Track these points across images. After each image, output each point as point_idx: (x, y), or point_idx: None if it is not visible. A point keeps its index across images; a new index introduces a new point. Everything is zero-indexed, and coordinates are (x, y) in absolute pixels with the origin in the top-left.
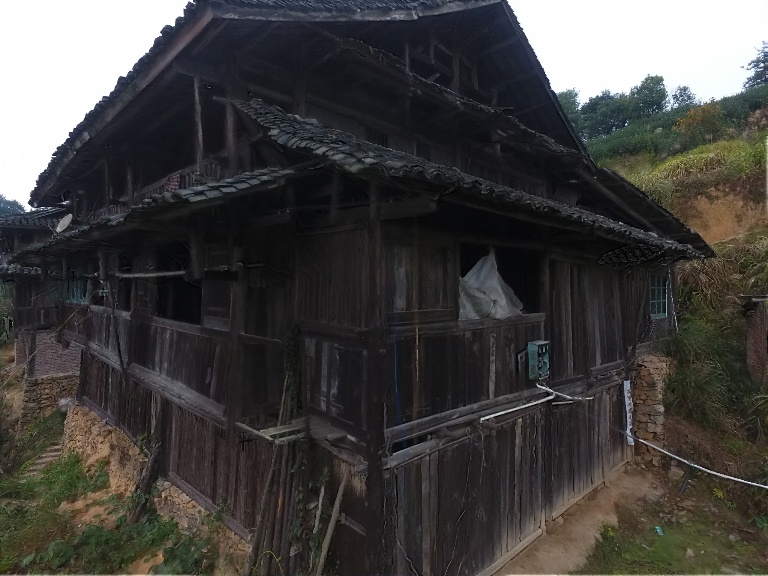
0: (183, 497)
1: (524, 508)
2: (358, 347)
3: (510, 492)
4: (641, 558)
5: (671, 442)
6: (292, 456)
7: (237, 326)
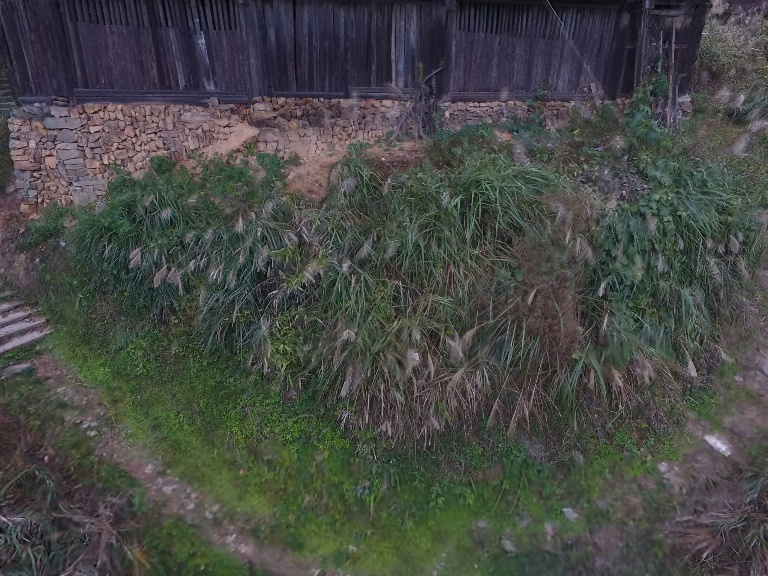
0: (478, 104)
1: None
2: None
3: None
4: None
5: None
6: None
7: None
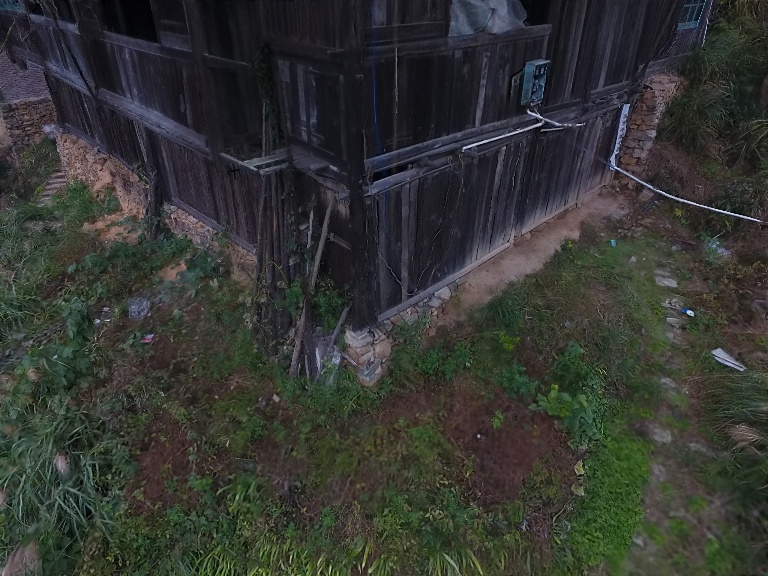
0: (191, 219)
1: (496, 226)
2: (334, 71)
3: (485, 214)
4: (590, 264)
5: (651, 167)
6: (280, 184)
7: (198, 45)
